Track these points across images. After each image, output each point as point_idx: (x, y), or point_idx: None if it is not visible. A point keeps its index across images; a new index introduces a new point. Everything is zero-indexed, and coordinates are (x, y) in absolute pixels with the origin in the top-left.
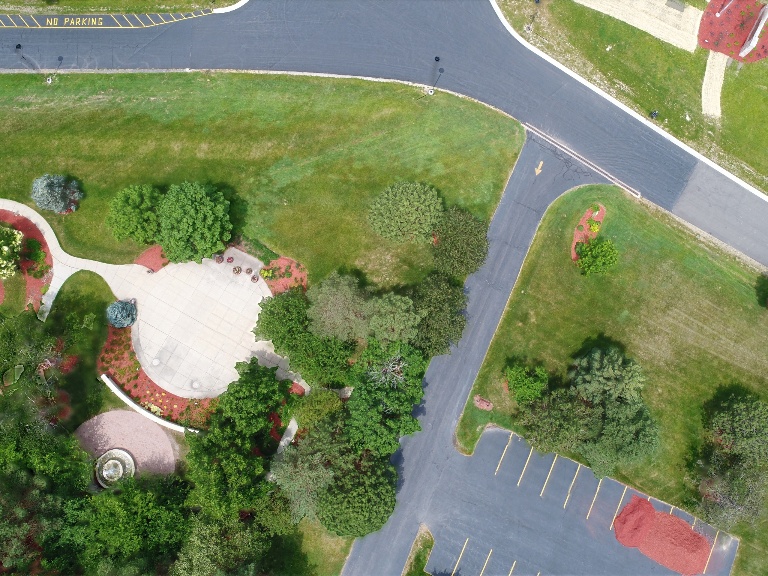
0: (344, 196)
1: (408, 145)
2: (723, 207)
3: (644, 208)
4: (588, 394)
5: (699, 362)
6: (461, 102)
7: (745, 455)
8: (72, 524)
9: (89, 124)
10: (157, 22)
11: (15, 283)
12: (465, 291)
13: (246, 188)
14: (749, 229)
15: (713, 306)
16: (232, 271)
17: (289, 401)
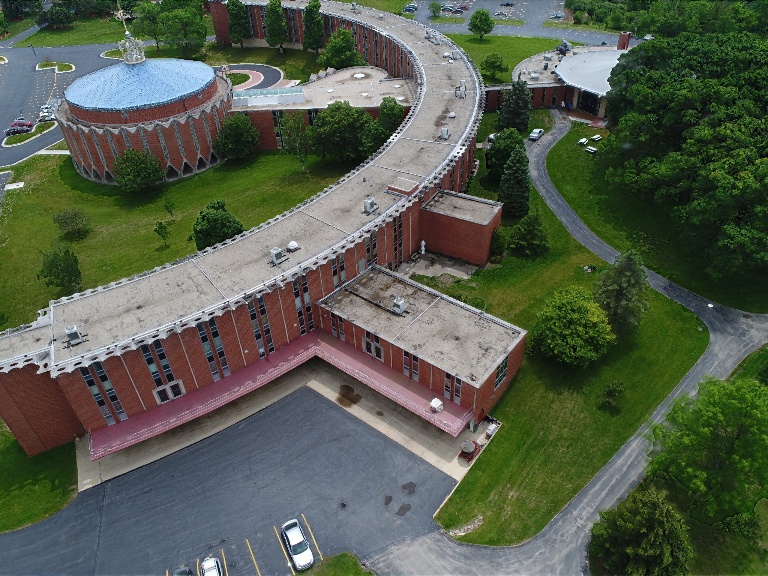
0: None
1: None
2: None
3: None
4: (19, 7)
5: None
6: None
7: None
8: None
9: None
10: (146, 45)
11: None
12: None
13: None
14: None
15: None
16: None
17: None
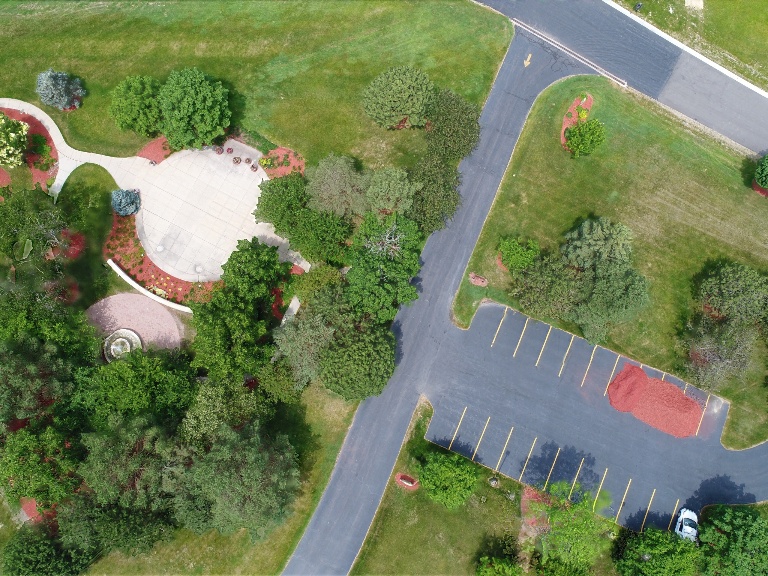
0: (339, 89)
1: (400, 41)
2: (707, 94)
3: (631, 97)
4: (579, 261)
5: (687, 238)
6: None
7: (733, 314)
8: (82, 390)
9: (90, 27)
10: None
11: (22, 176)
12: None
13: (244, 84)
14: (733, 115)
15: (700, 186)
16: (232, 161)
17: (290, 281)
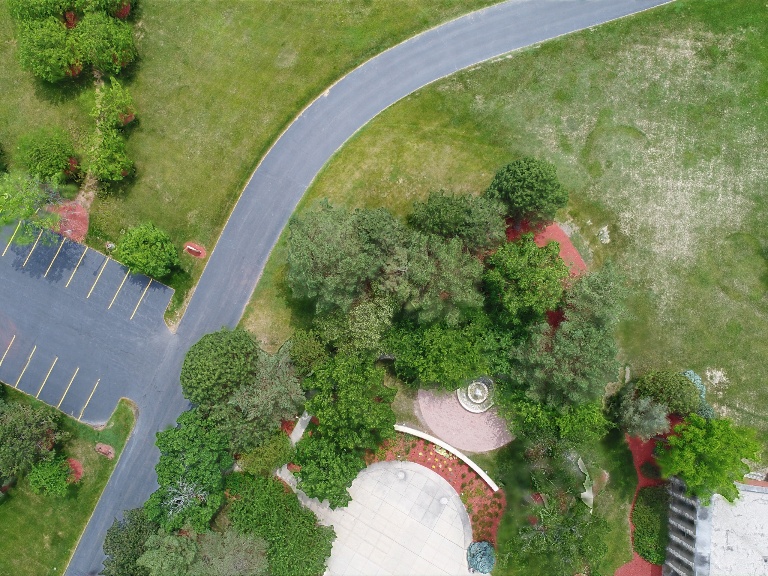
0: None
1: None
2: None
3: None
4: None
5: None
6: None
7: None
8: None
9: None
10: None
11: None
12: None
13: None
14: None
15: None
16: None
17: None
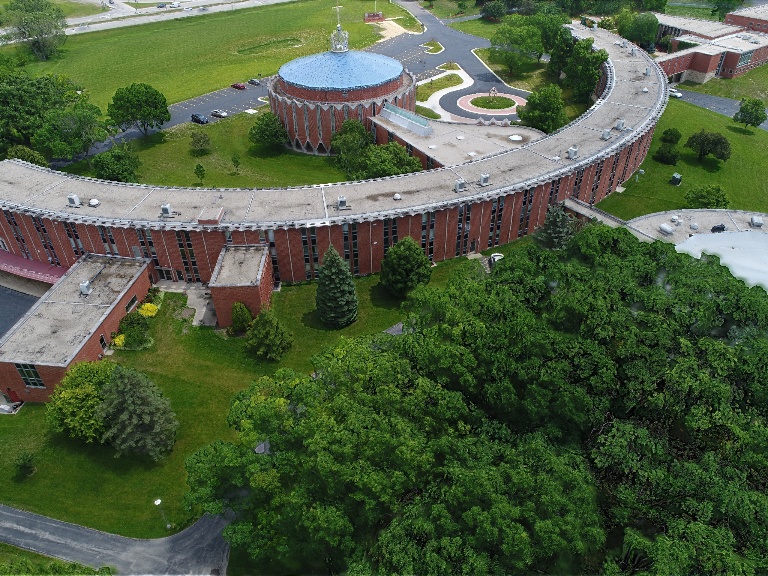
0: None
1: None
2: None
3: None
4: None
5: None
6: None
7: None
8: None
9: None
10: None
11: None
12: None
13: None
14: None
15: None
16: None
17: None
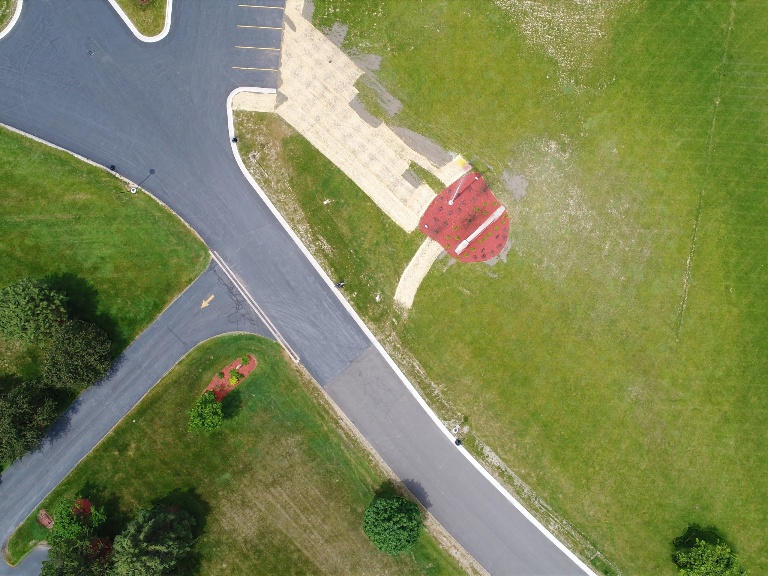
0: (2, 268)
1: (89, 236)
2: (377, 400)
3: (298, 375)
4: None
5: (279, 550)
6: (159, 210)
7: None
8: None
9: None
10: None
11: None
12: (77, 402)
13: None
14: (394, 431)
15: (320, 497)
16: None
17: None
